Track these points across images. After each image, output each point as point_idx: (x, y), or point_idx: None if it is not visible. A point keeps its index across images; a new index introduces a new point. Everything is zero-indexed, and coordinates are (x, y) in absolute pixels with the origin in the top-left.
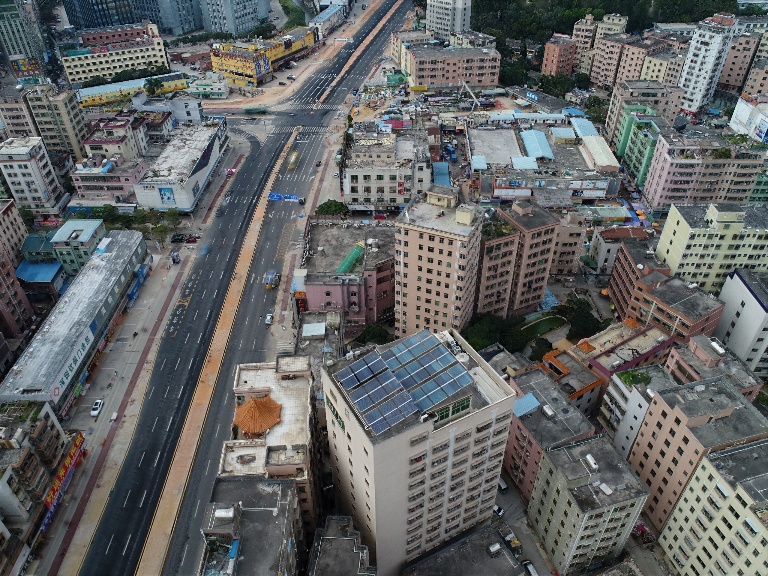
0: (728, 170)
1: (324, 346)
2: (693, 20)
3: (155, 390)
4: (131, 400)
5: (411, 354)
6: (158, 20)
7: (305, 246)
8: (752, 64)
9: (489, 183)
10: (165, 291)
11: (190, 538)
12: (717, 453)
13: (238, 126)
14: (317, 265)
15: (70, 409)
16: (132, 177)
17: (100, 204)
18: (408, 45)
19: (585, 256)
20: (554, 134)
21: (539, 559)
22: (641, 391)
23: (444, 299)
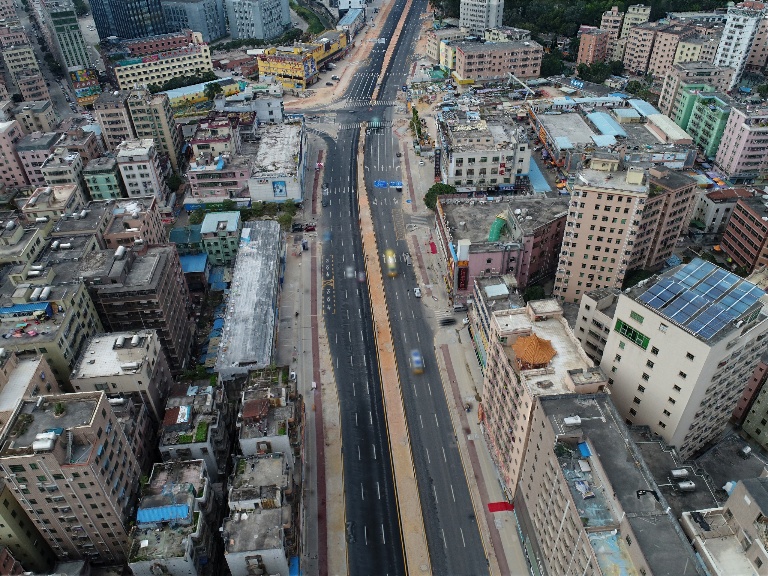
0: None
1: (510, 304)
2: (702, 9)
3: (340, 360)
4: (322, 370)
5: (695, 278)
6: None
7: (444, 222)
8: None
9: (577, 161)
10: (307, 275)
11: (434, 480)
12: None
13: None
14: (463, 238)
15: None
16: (247, 172)
17: (215, 200)
18: (448, 42)
19: None
20: (620, 115)
21: None
22: None
23: (612, 255)
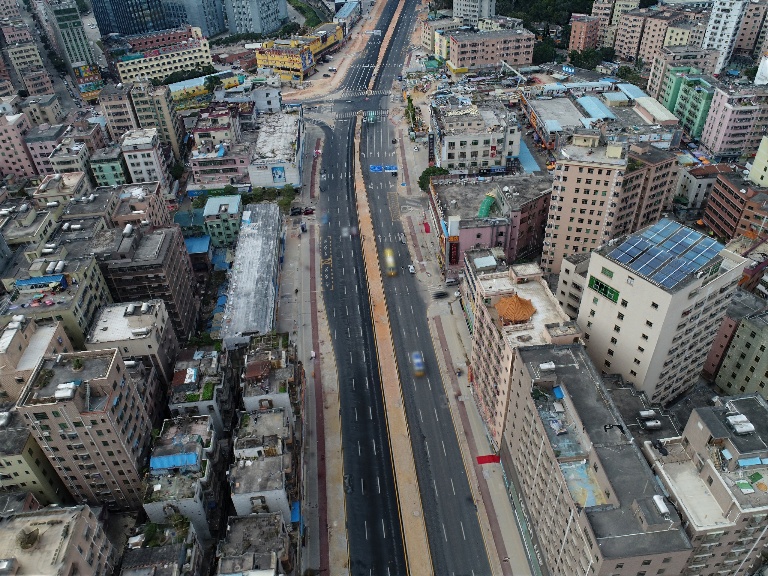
0: None
1: None
2: None
3: (337, 332)
4: (320, 341)
5: (662, 236)
6: None
7: (436, 202)
8: (762, 28)
9: None
10: (306, 255)
11: (426, 437)
12: None
13: None
14: None
15: None
16: (247, 159)
17: (216, 186)
18: (442, 32)
19: None
20: (609, 98)
21: None
22: None
23: (595, 226)
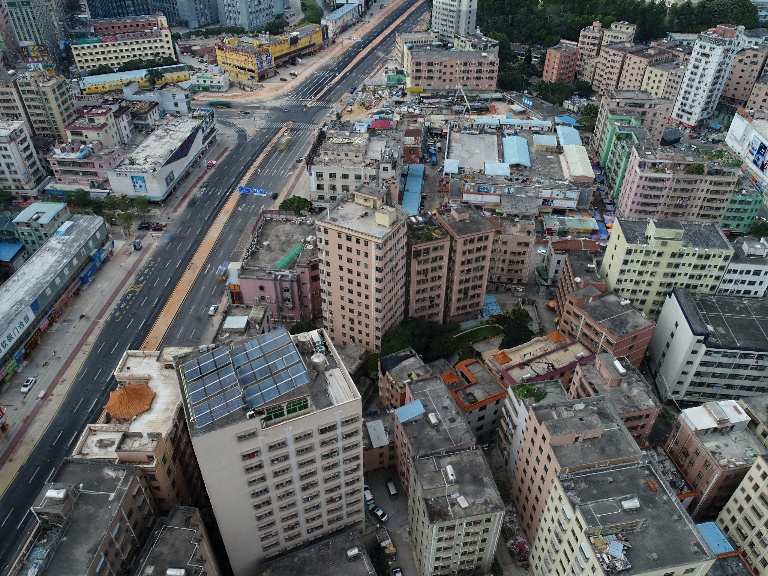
0: (700, 186)
1: None
2: None
3: (87, 372)
4: (62, 380)
5: (261, 351)
6: (175, 13)
7: (253, 240)
8: None
9: (458, 187)
10: (120, 276)
11: None
12: (570, 474)
13: (230, 119)
14: (260, 259)
15: (3, 384)
16: (106, 164)
17: (75, 188)
18: (410, 46)
19: (540, 266)
20: (535, 141)
21: (412, 568)
22: (528, 405)
23: (365, 300)
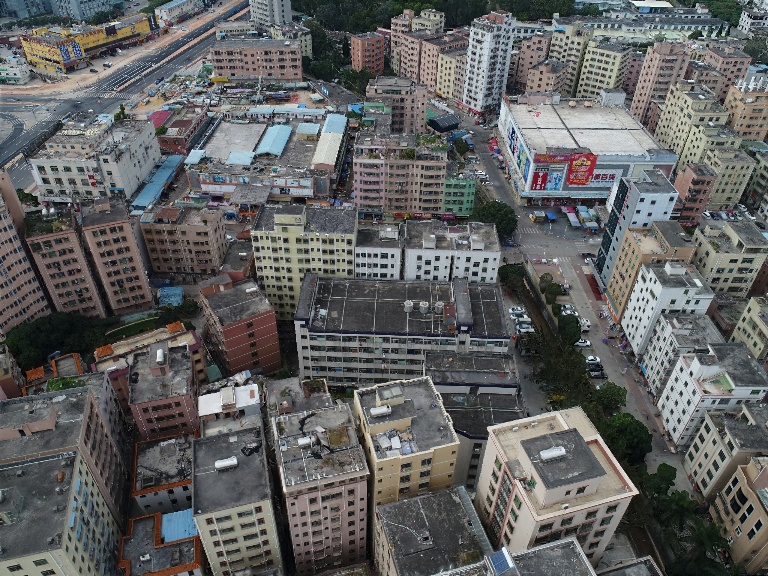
0: (414, 171)
1: None
2: (530, 18)
3: None
4: None
5: None
6: (3, 2)
7: None
8: None
9: (196, 178)
10: None
11: None
12: None
13: (14, 113)
14: None
15: None
16: None
17: None
18: (223, 35)
19: None
20: (297, 130)
21: None
22: None
23: None
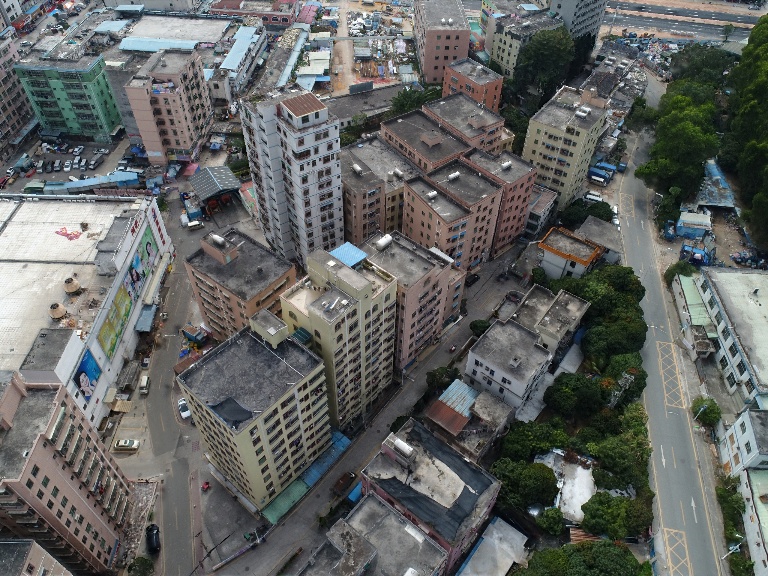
0: None
1: None
2: None
3: None
4: None
5: None
6: None
7: None
8: None
9: None
10: None
11: None
12: None
13: None
14: None
15: None
16: None
17: None
18: None
19: None
20: None
21: None
22: None
23: None
